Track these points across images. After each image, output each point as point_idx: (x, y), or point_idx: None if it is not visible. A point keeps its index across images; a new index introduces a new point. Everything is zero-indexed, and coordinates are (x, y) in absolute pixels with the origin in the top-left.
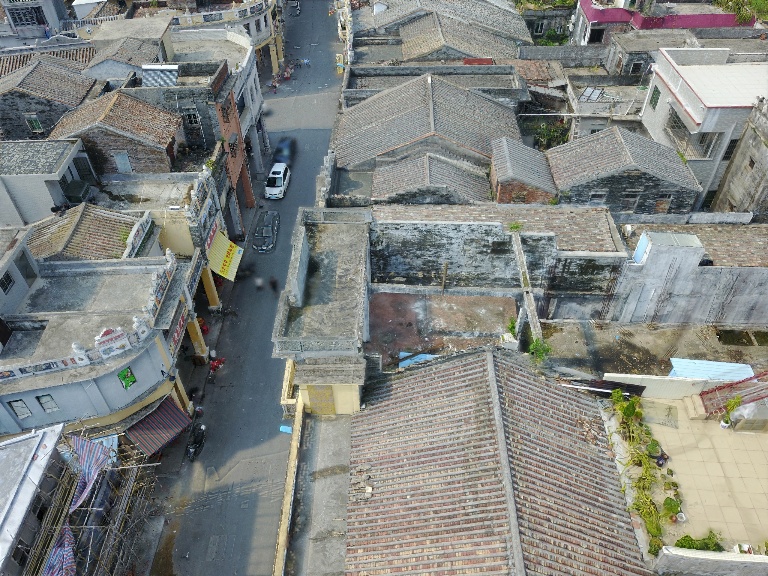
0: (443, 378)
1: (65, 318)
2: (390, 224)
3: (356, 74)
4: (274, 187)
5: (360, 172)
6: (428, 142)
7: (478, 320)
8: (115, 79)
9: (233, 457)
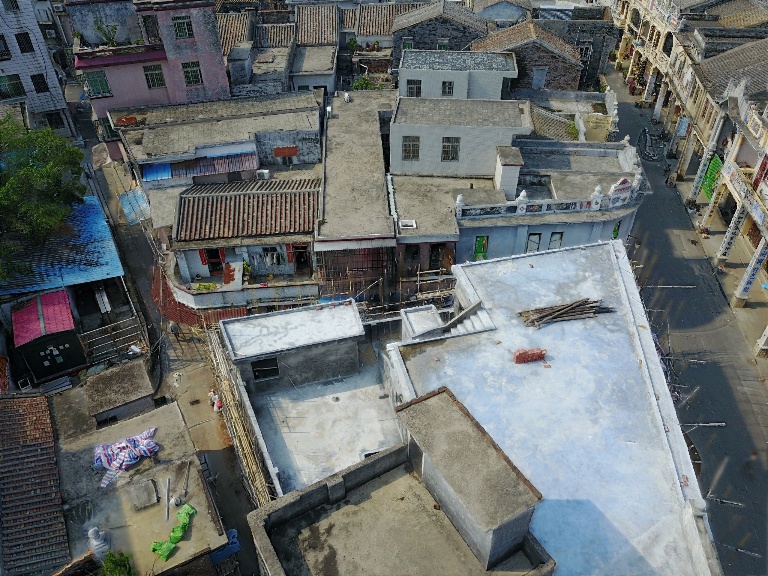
0: None
1: (565, 175)
2: None
3: None
4: None
5: (755, 101)
6: None
7: None
8: (502, 20)
9: None
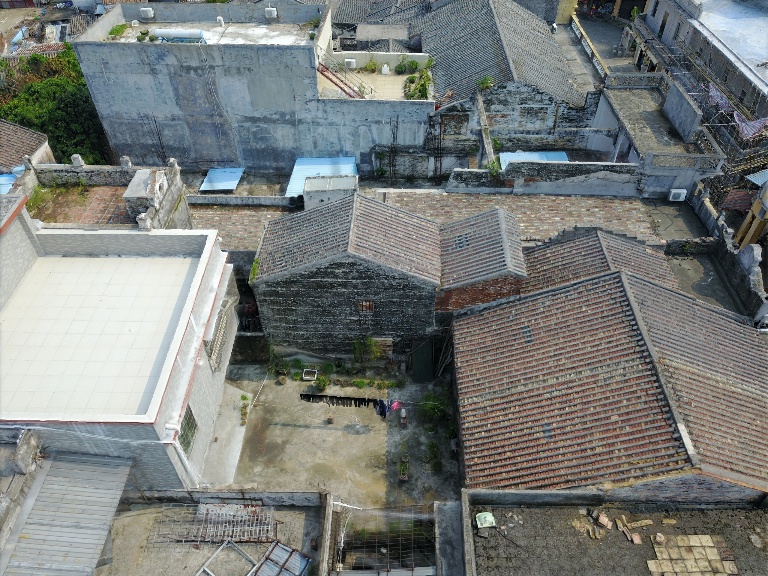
0: None
1: None
2: None
3: None
4: None
5: None
6: None
7: None
8: None
9: None
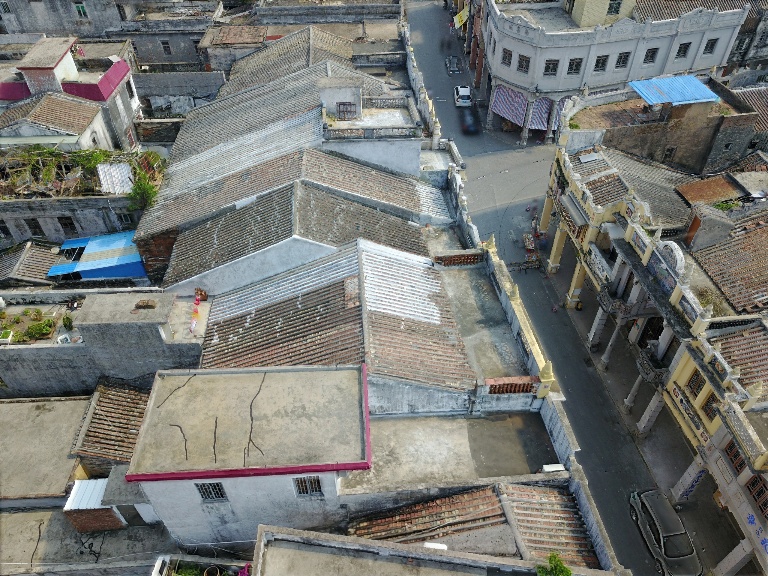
0: None
1: None
2: None
3: (394, 10)
4: None
5: None
6: None
7: None
8: None
9: (429, 6)
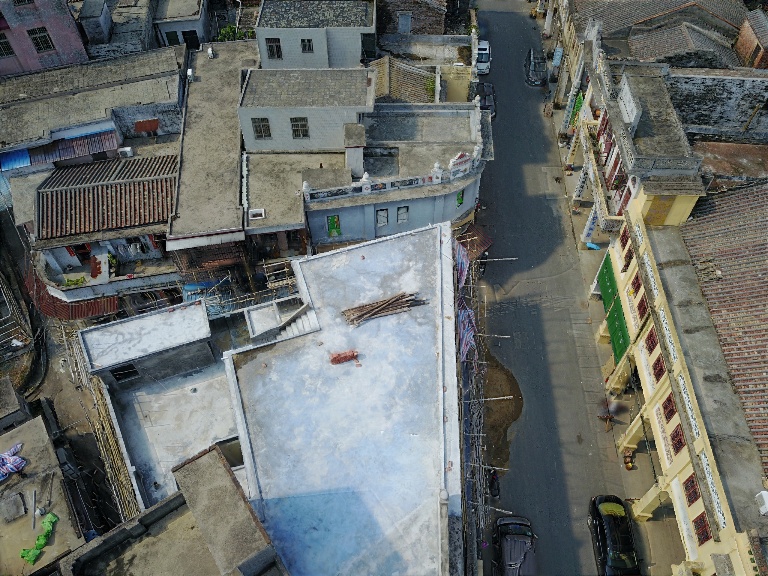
0: (767, 195)
1: (412, 146)
2: (682, 78)
3: None
4: (481, 62)
5: (614, 40)
6: (686, 12)
7: (743, 167)
8: None
9: (512, 278)
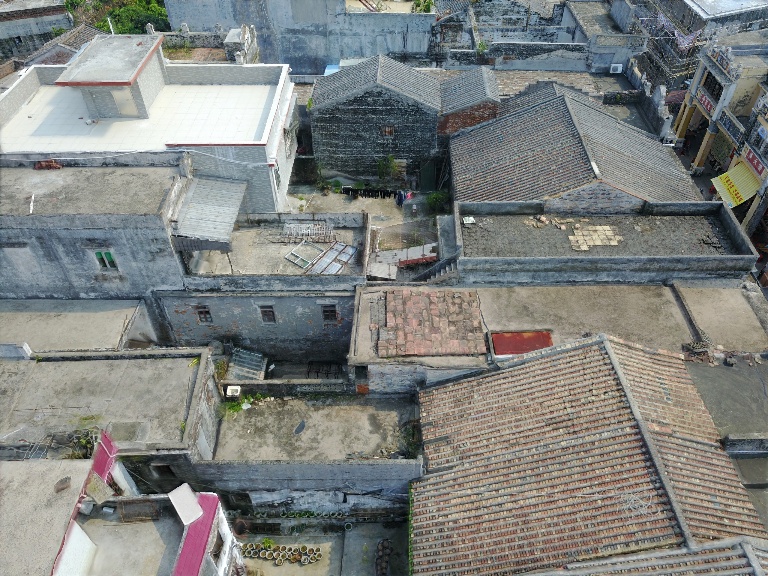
0: None
1: None
2: None
3: (740, 265)
4: None
5: None
6: None
7: None
8: None
9: None
